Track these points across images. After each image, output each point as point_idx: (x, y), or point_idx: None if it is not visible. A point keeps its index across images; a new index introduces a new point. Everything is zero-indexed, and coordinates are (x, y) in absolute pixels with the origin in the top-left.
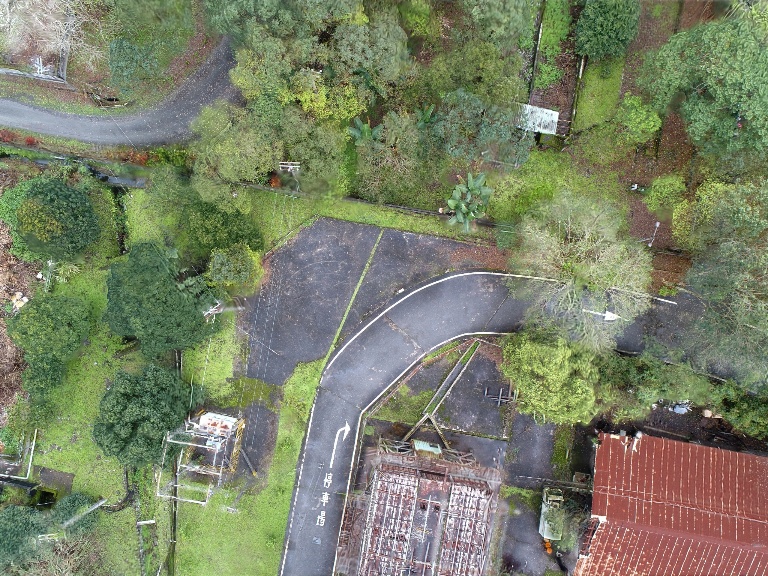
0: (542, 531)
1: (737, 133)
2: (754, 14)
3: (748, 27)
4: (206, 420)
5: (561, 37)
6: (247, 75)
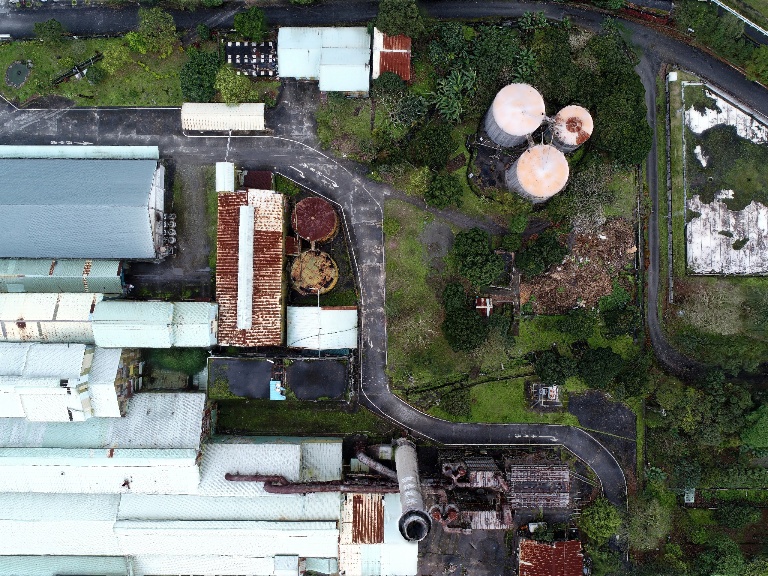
0: (532, 524)
1: (706, 571)
2: (749, 569)
3: (744, 568)
4: (555, 388)
5: (723, 498)
6: (695, 394)
